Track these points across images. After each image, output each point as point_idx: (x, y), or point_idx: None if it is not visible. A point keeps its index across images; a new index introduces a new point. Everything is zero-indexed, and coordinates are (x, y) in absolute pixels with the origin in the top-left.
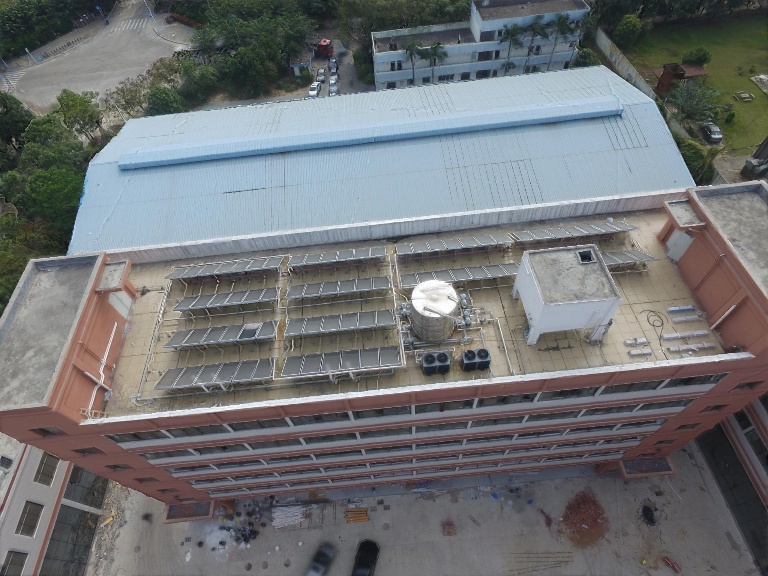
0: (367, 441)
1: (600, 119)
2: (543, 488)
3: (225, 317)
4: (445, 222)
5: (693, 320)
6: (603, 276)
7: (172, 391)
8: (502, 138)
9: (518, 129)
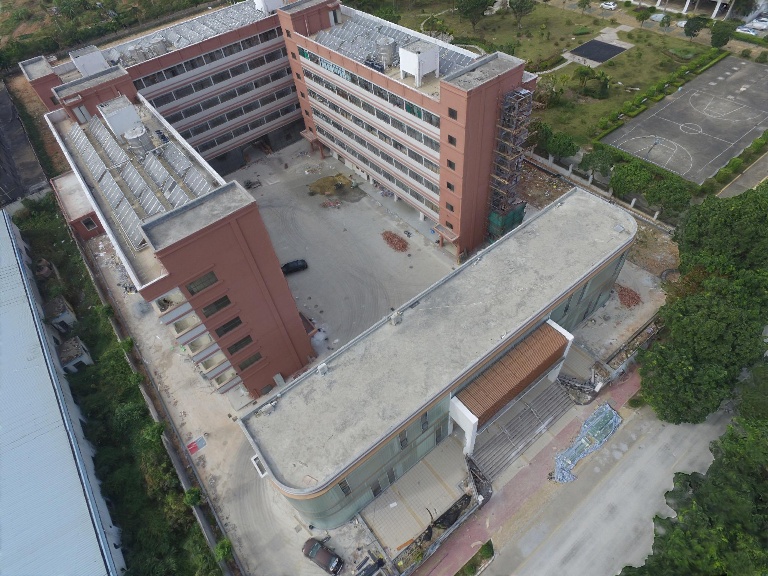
0: None
1: None
2: None
3: None
4: None
5: None
6: None
7: None
8: None
9: None
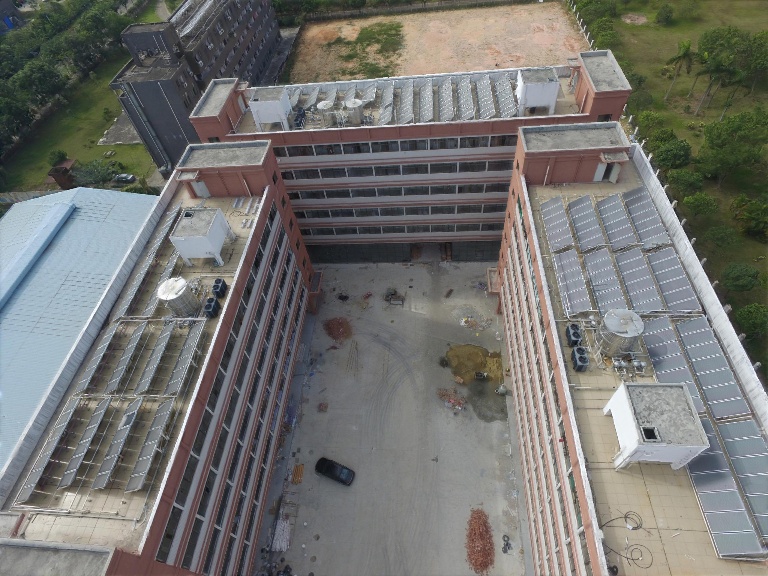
0: (243, 391)
1: (70, 219)
2: (315, 346)
3: (100, 451)
4: (114, 288)
5: (244, 201)
6: (204, 212)
7: (147, 481)
8: (34, 283)
9: (34, 270)
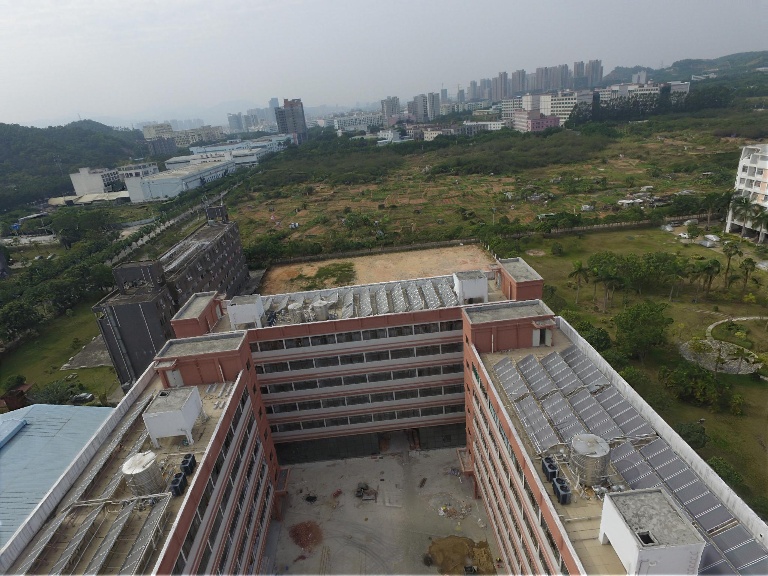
0: None
1: (16, 436)
2: (280, 557)
3: None
4: (70, 475)
5: (217, 386)
6: (180, 390)
7: None
8: None
9: None
